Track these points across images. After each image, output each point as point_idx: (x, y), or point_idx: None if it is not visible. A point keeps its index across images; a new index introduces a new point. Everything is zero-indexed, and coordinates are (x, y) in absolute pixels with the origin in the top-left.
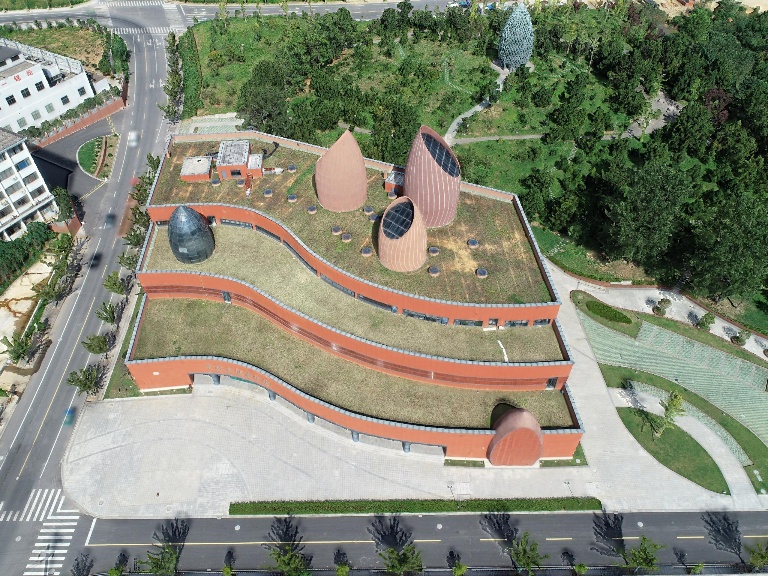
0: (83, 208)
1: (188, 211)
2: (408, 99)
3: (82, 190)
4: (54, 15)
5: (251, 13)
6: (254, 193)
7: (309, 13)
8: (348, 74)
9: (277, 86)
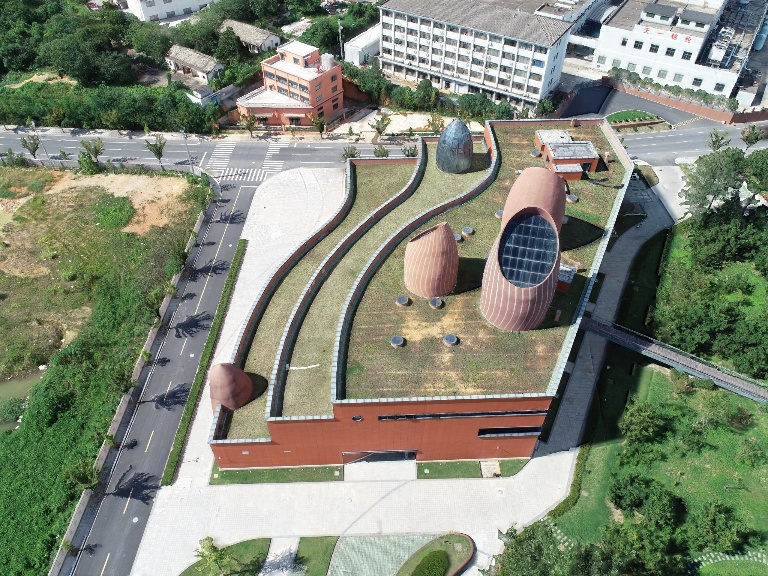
0: None
1: (457, 126)
2: None
3: None
4: None
5: None
6: None
7: None
8: None
9: (764, 182)
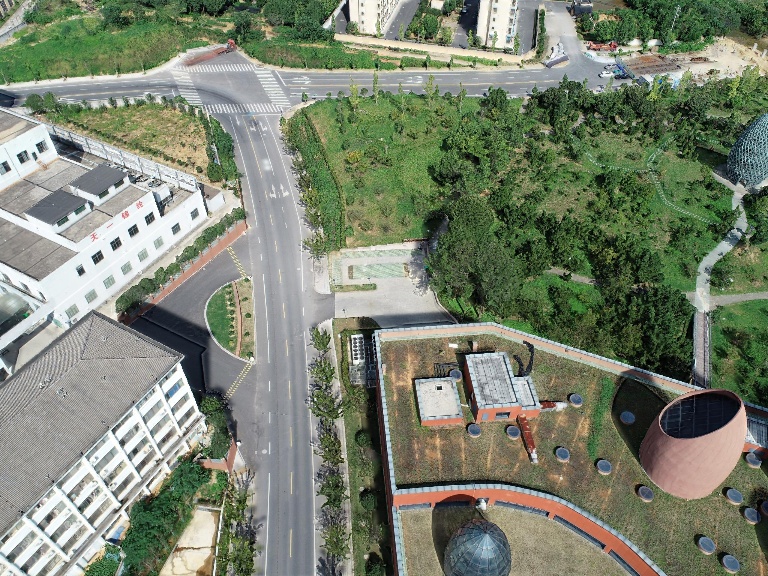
0: (232, 414)
1: (496, 539)
2: (625, 228)
3: (224, 381)
4: (125, 85)
5: (365, 83)
6: (539, 453)
7: (436, 84)
8: (540, 191)
9: None
